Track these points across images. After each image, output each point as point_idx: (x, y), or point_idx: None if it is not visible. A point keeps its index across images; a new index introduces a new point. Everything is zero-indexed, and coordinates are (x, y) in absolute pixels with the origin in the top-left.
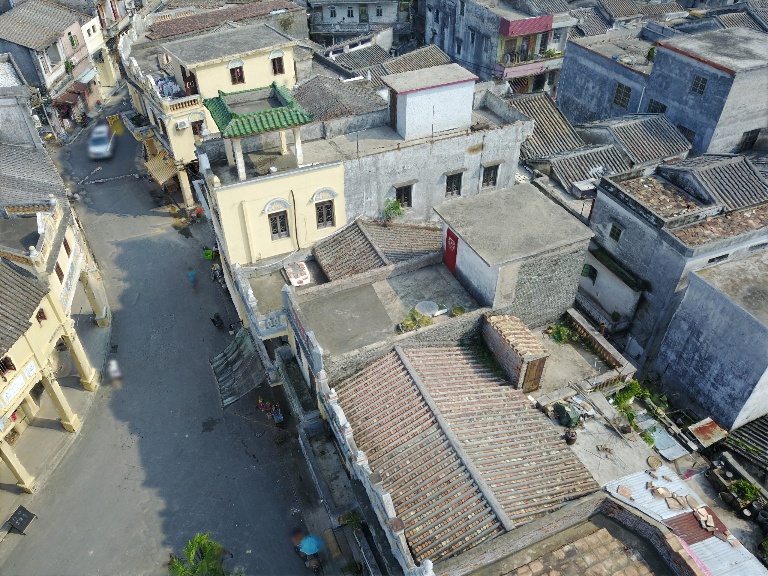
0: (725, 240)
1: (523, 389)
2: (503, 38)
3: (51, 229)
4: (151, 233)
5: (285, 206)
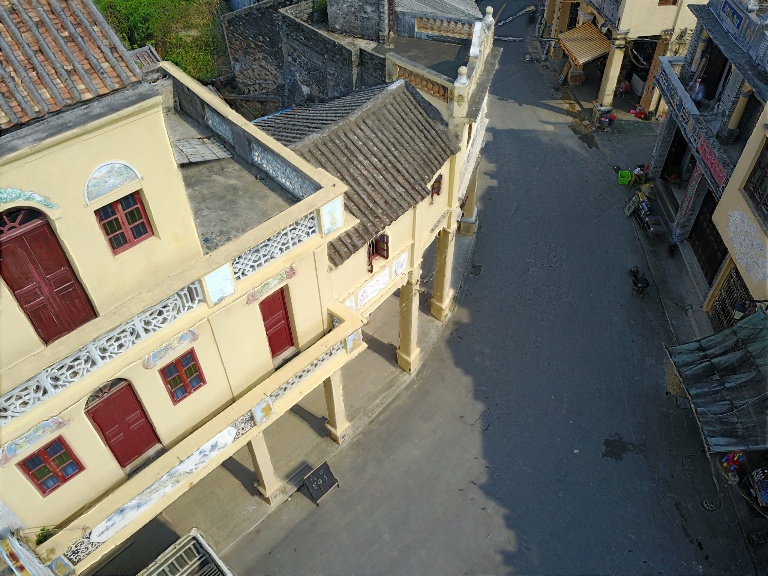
0: None
1: None
2: None
3: (480, 58)
4: (541, 130)
5: None
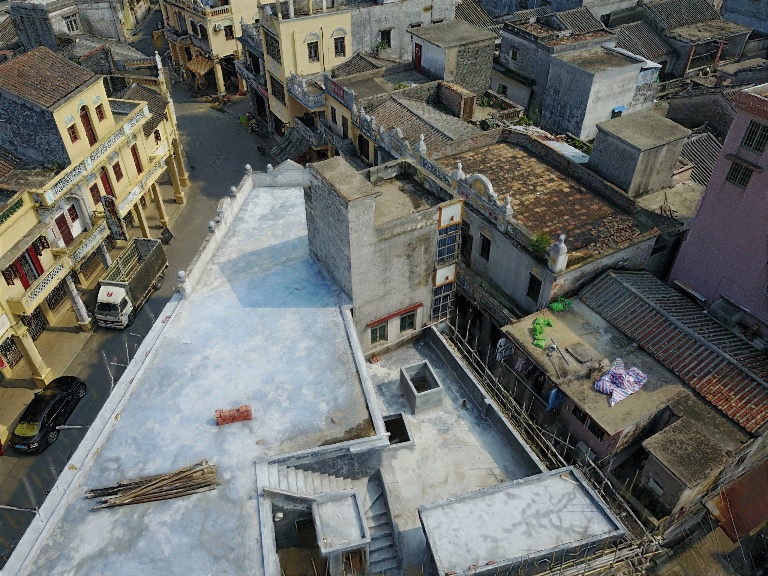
0: (572, 44)
1: (463, 119)
2: None
3: None
4: (196, 111)
5: (317, 38)
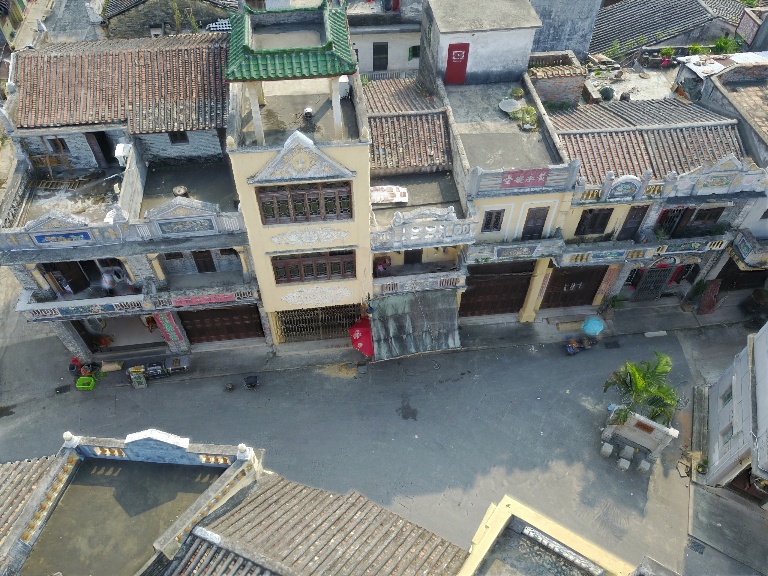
0: None
1: None
2: None
3: None
4: None
5: None
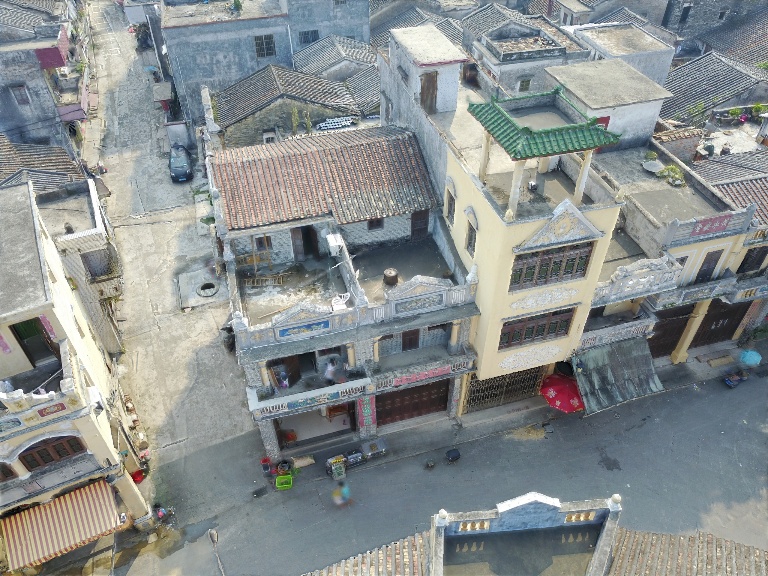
0: None
1: None
2: (45, 74)
3: None
4: None
5: None
